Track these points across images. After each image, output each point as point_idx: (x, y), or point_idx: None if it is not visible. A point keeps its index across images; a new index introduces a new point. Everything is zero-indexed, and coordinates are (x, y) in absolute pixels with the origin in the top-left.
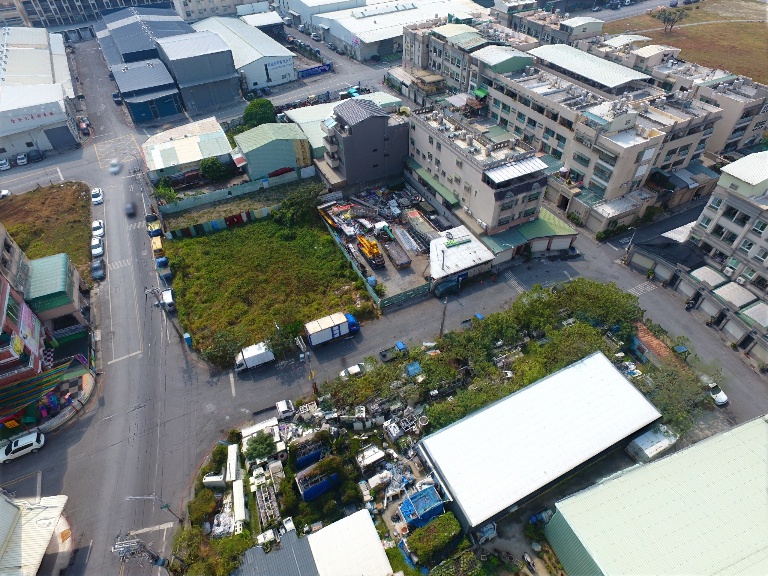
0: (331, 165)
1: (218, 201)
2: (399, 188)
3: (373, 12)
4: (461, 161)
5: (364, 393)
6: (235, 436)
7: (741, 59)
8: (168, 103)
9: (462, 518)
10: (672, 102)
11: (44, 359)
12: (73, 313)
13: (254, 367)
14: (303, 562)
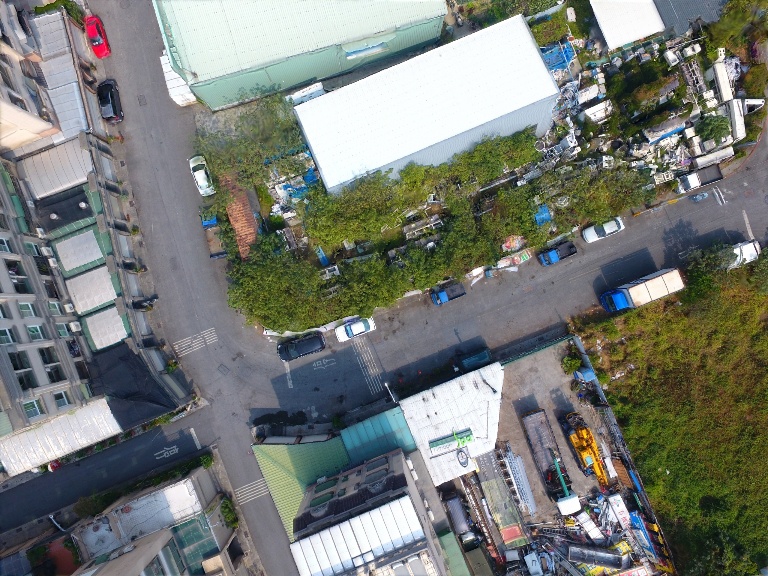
0: None
1: None
2: None
3: None
4: None
5: None
6: (739, 150)
7: None
8: None
9: None
10: None
11: None
12: None
13: None
14: (668, 8)
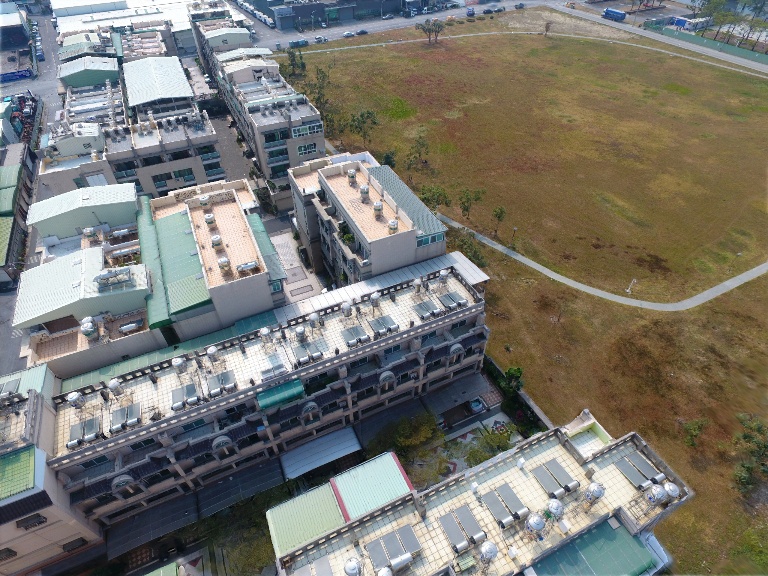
0: None
1: None
2: None
3: (105, 16)
4: None
5: None
6: None
7: (470, 73)
8: None
9: None
10: (186, 123)
11: None
12: None
13: None
14: None
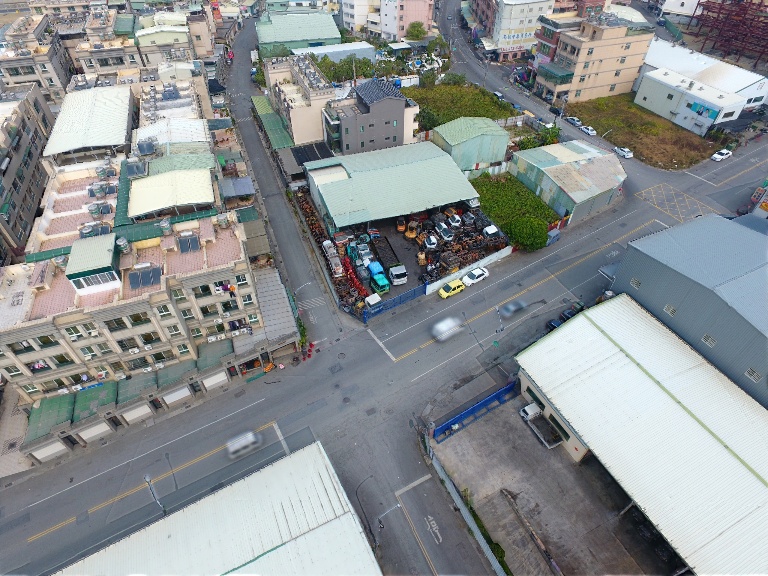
0: None
1: None
2: None
3: None
4: None
5: None
6: None
7: None
8: None
9: None
10: None
11: None
12: None
13: None
14: (412, 44)
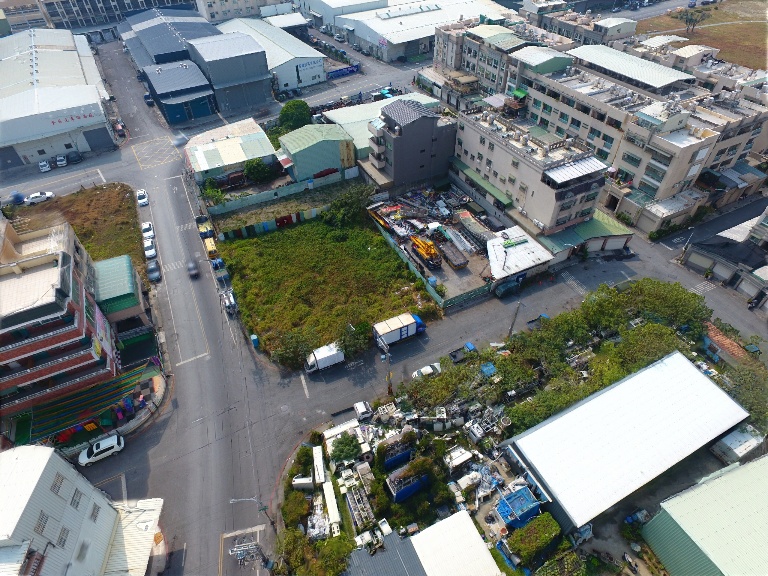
0: (377, 166)
1: (264, 202)
2: (445, 189)
3: (398, 13)
4: (518, 161)
5: (445, 394)
6: (317, 438)
7: (766, 59)
8: (202, 104)
9: (562, 519)
10: (719, 102)
11: (116, 361)
12: (139, 315)
13: (324, 368)
14: (410, 564)
